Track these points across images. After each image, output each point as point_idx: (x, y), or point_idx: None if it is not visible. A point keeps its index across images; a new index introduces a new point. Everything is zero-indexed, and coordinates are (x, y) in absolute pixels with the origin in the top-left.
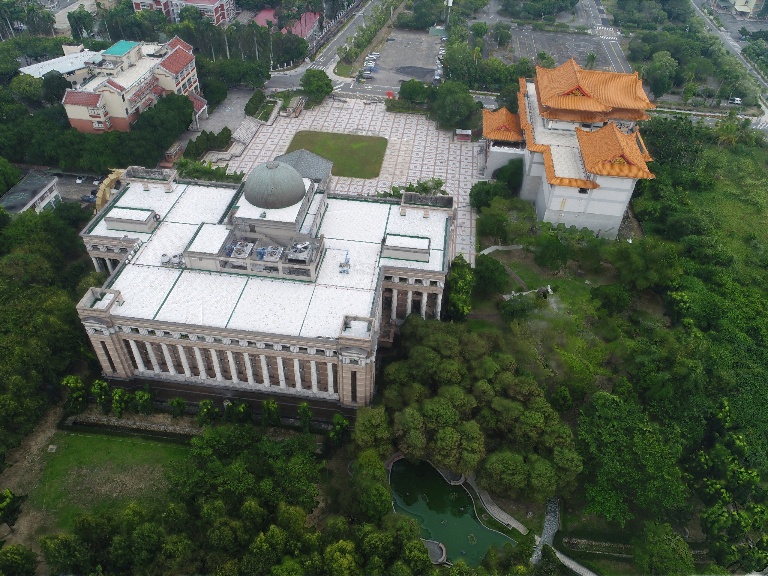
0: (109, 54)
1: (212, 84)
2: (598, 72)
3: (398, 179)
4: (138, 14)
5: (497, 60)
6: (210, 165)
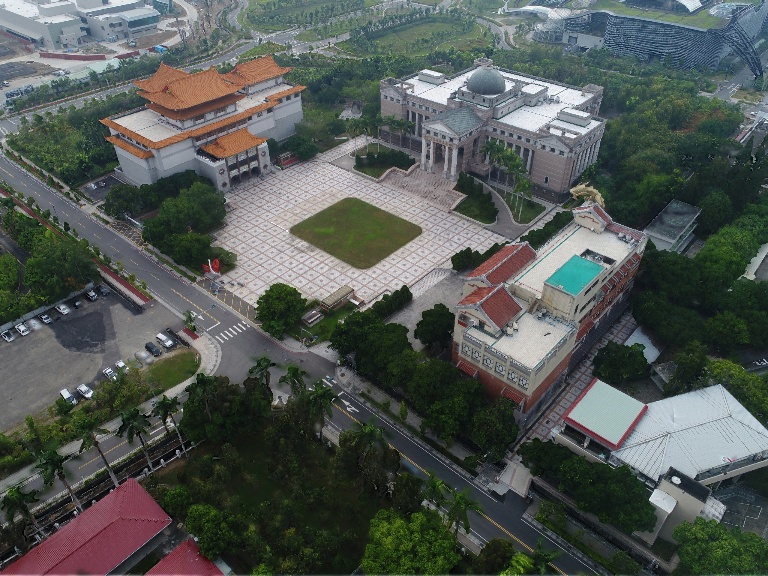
0: (594, 262)
1: (442, 305)
2: (180, 71)
3: (334, 191)
4: (521, 562)
5: (6, 258)
6: (508, 153)
